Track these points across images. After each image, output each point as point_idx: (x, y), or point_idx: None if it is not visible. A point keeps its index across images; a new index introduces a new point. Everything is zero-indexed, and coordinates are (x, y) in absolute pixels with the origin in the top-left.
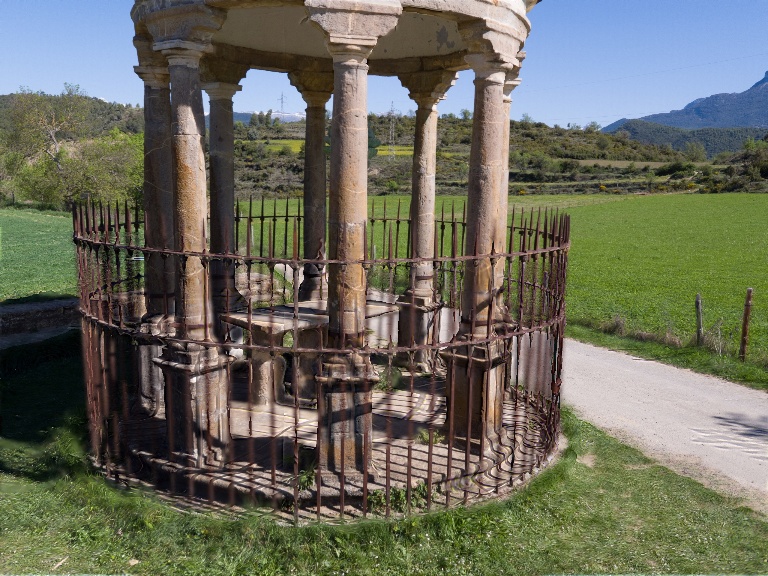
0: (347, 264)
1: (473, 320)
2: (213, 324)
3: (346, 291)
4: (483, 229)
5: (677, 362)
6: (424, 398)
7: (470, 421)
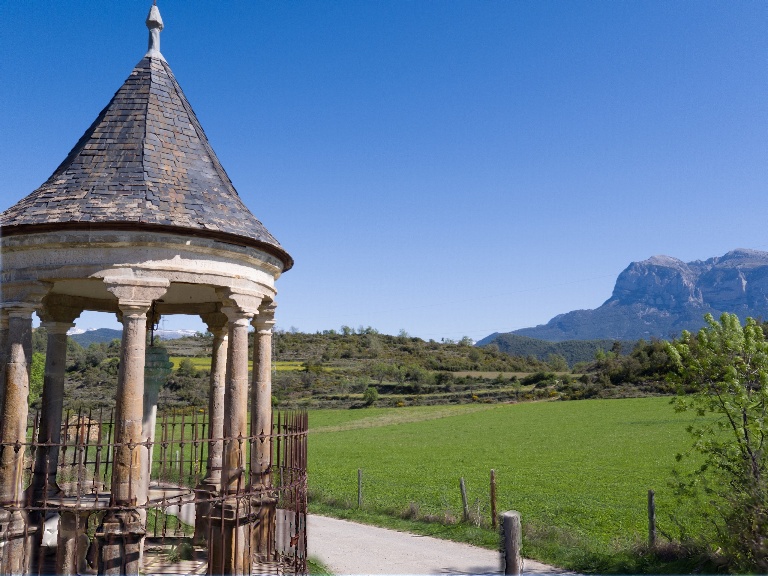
0: (125, 449)
1: (227, 490)
2: (32, 515)
3: (123, 468)
4: (233, 423)
5: (444, 535)
6: (205, 564)
7: (223, 569)
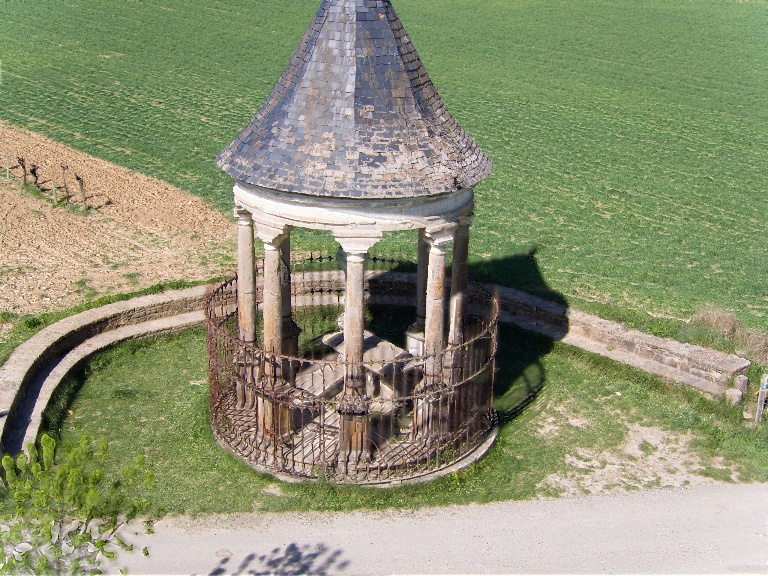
0: None
1: None
2: None
3: None
4: None
5: None
6: None
7: None
